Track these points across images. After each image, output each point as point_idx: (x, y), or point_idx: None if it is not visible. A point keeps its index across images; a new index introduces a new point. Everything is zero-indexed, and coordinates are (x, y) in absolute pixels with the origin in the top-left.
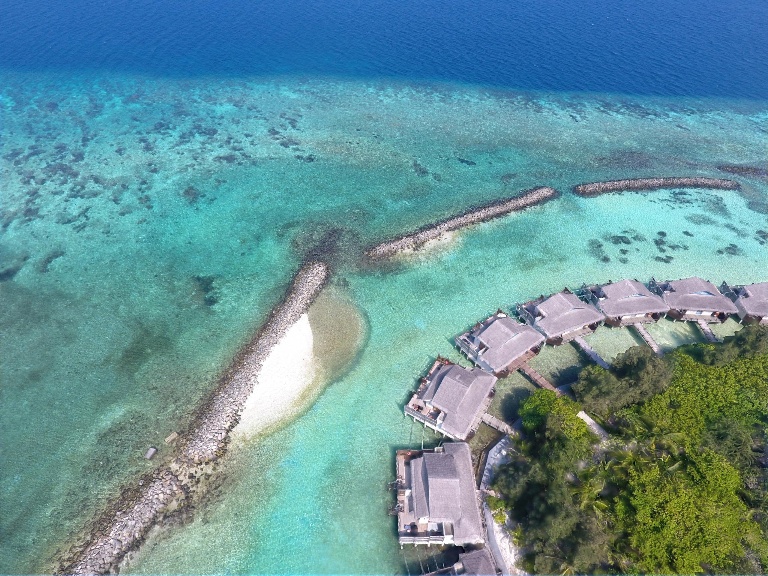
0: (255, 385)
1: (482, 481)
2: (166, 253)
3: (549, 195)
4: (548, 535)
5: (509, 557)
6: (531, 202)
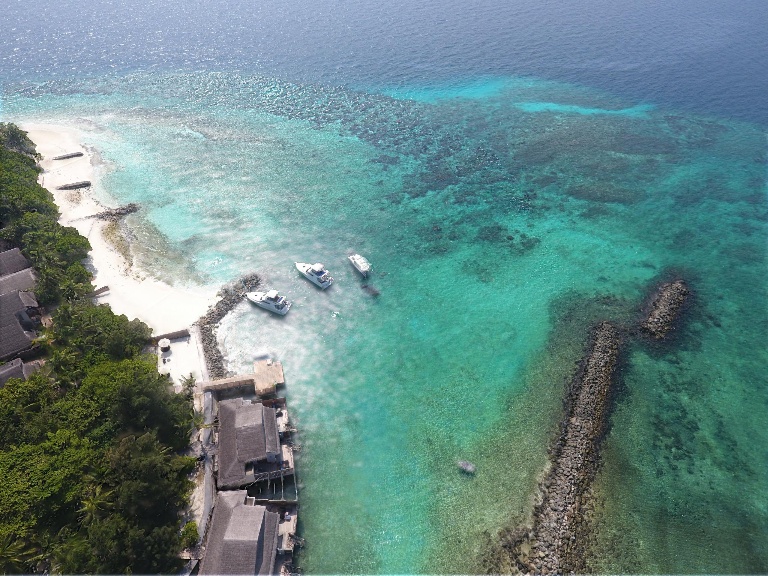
0: None
1: (191, 571)
2: None
3: None
4: (160, 476)
5: (198, 493)
6: None
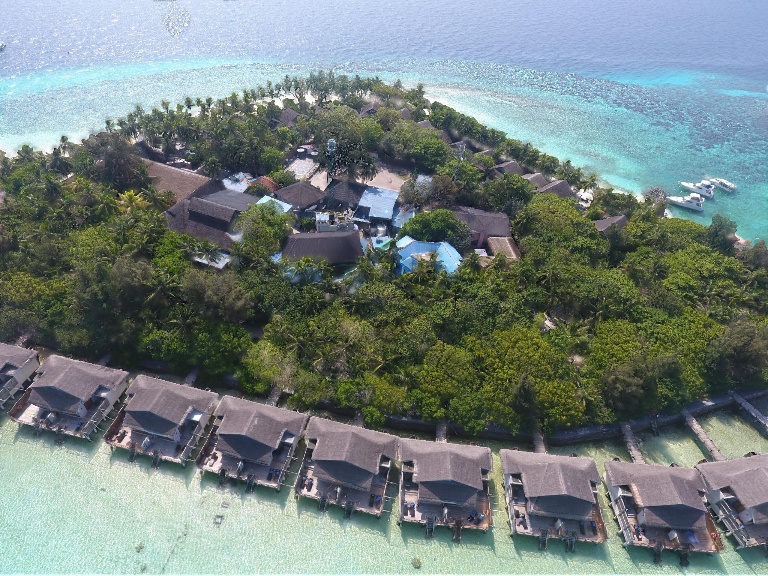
0: None
1: None
2: None
3: None
4: None
5: None
6: None
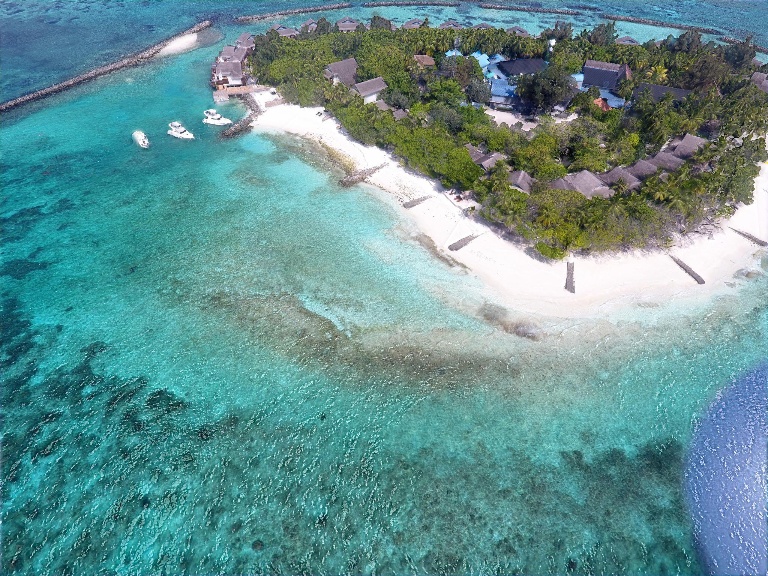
0: (168, 46)
1: None
2: (131, 19)
3: (346, 5)
4: None
5: None
6: (333, 7)
